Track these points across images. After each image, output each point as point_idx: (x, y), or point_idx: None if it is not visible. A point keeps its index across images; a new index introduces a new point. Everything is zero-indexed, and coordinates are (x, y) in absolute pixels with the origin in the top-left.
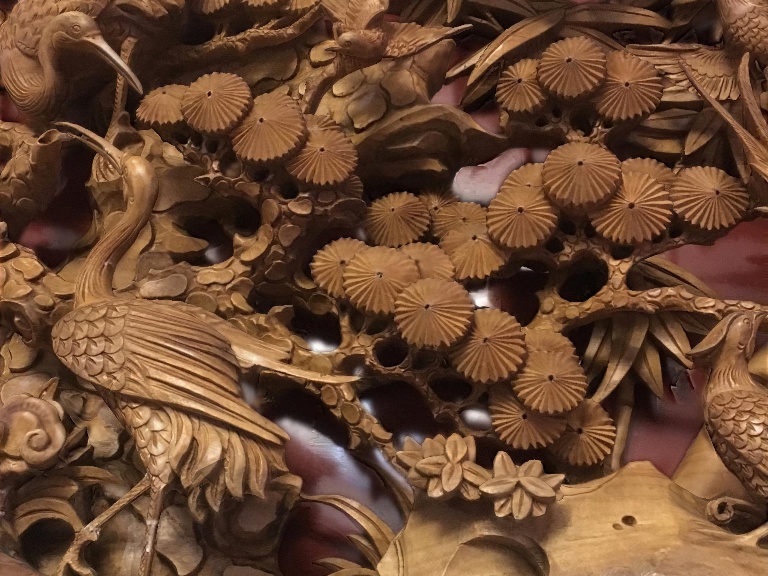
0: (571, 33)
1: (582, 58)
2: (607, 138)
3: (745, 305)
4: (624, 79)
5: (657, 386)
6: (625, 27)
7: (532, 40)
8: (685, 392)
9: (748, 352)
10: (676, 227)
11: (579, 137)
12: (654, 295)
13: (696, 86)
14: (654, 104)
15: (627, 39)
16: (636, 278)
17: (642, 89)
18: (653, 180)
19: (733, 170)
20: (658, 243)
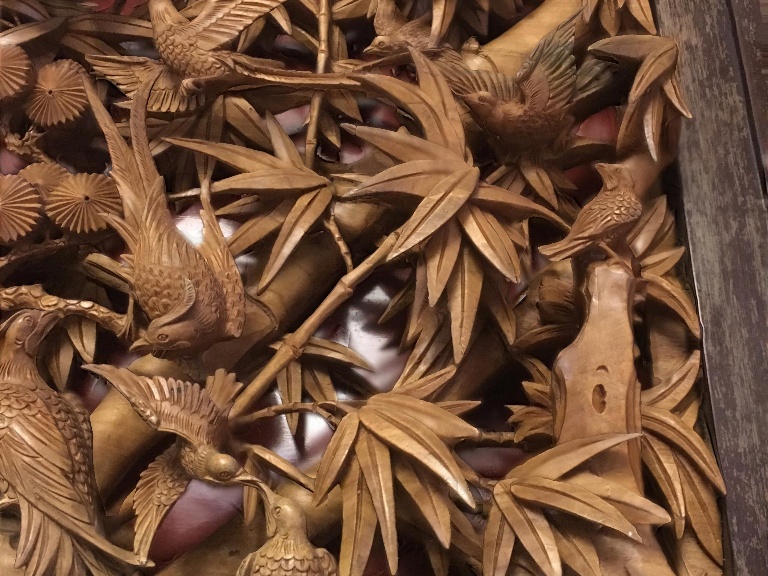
0: (71, 41)
1: (4, 65)
2: (43, 142)
3: (83, 305)
4: (49, 87)
5: (60, 380)
6: (128, 38)
7: (20, 45)
8: (99, 387)
9: (26, 348)
10: (56, 229)
11: (15, 140)
12: (9, 293)
13: (87, 97)
14: (78, 112)
15: (133, 49)
16: (76, 277)
17: (66, 97)
18: (25, 184)
19: (196, 179)
20: (38, 244)
